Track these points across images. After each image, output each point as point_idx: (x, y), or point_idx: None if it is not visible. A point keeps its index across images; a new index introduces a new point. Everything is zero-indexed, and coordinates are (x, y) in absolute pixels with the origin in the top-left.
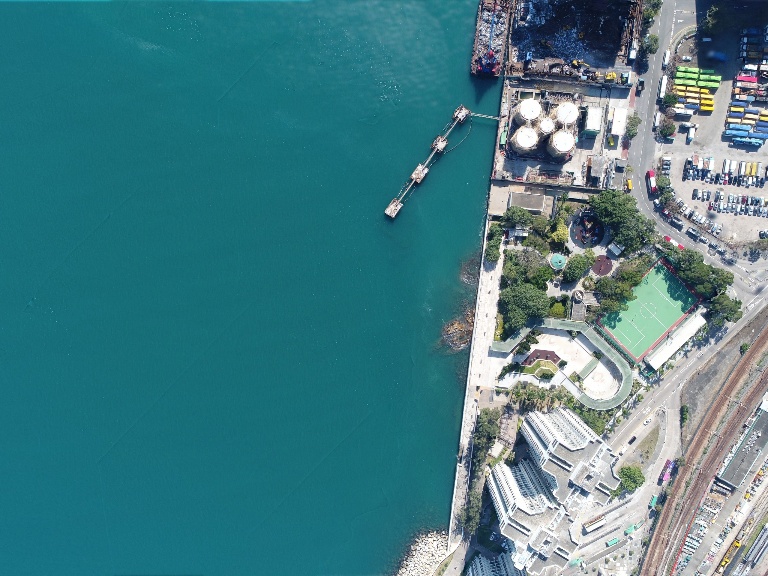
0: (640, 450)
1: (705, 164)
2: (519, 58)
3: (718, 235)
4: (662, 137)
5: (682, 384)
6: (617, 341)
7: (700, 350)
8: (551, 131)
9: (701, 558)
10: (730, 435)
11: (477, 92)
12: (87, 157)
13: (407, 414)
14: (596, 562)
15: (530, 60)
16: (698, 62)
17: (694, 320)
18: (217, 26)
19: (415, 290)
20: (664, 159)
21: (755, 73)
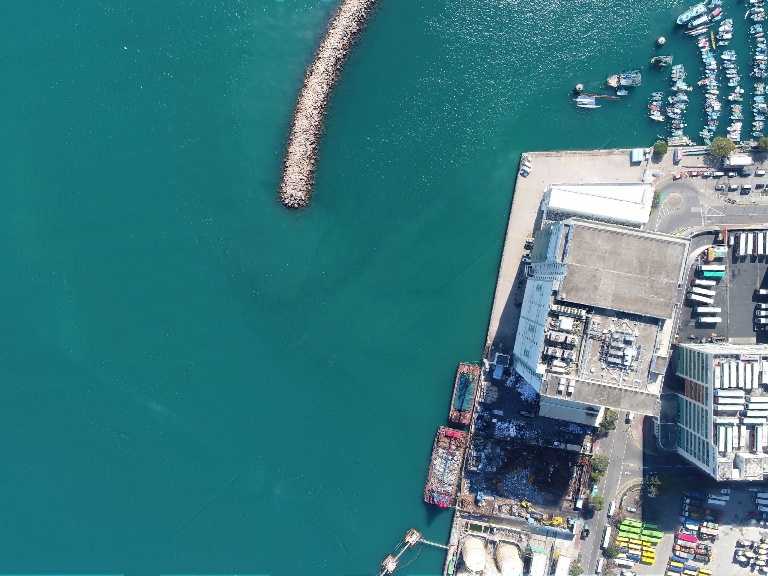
0: None
1: None
2: (471, 490)
3: None
4: None
5: None
6: None
7: None
8: None
9: None
10: None
11: (429, 516)
12: (47, 562)
13: None
14: None
15: (480, 500)
16: (642, 514)
17: None
18: (179, 461)
19: None
20: None
21: None
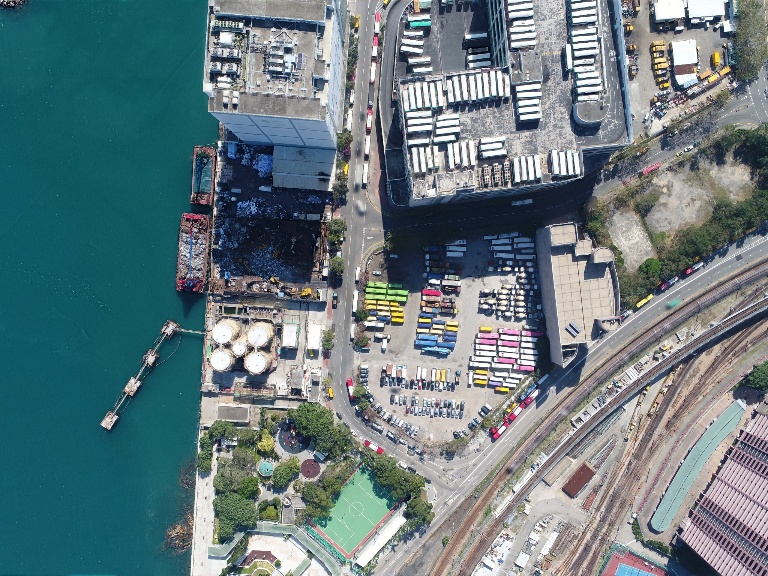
0: None
1: (398, 373)
2: (221, 274)
3: (416, 436)
4: (359, 346)
5: None
6: (329, 539)
7: (406, 544)
8: (243, 354)
9: None
10: None
11: (185, 306)
12: None
13: None
14: None
15: (228, 279)
16: (388, 276)
17: (394, 520)
18: None
19: (137, 496)
20: (361, 368)
21: (439, 287)
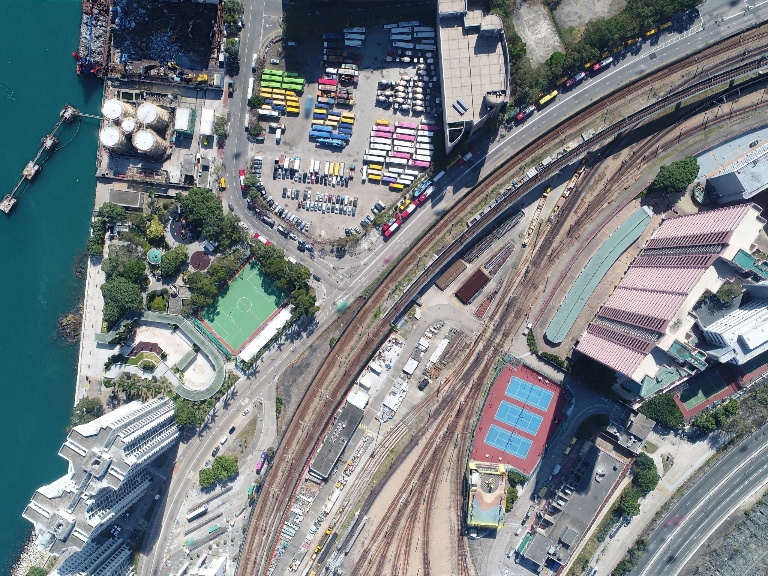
0: (239, 440)
1: (290, 164)
2: (121, 60)
3: (307, 232)
4: (254, 137)
5: (277, 376)
6: (215, 334)
7: (293, 343)
8: (131, 130)
9: (298, 545)
10: (319, 426)
11: (85, 92)
12: None
13: (26, 403)
14: (201, 548)
15: (125, 62)
16: (286, 65)
17: (280, 314)
18: None
19: (32, 283)
20: (255, 158)
21: (335, 76)
